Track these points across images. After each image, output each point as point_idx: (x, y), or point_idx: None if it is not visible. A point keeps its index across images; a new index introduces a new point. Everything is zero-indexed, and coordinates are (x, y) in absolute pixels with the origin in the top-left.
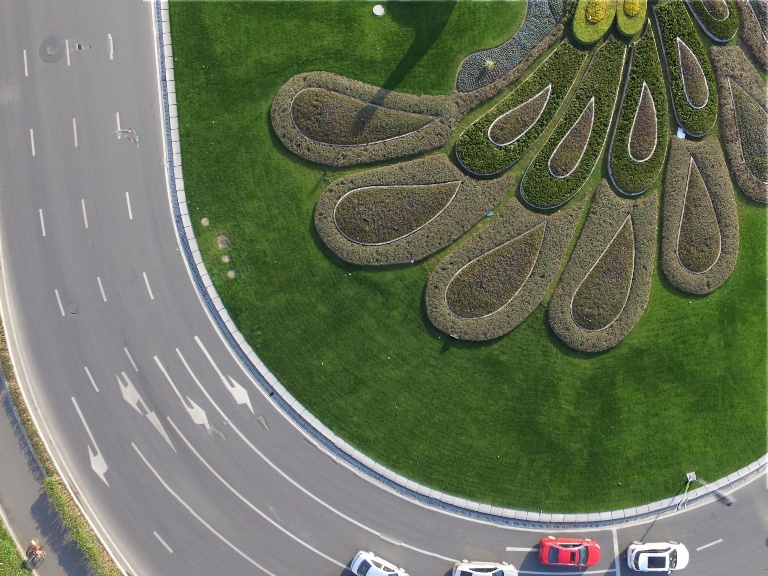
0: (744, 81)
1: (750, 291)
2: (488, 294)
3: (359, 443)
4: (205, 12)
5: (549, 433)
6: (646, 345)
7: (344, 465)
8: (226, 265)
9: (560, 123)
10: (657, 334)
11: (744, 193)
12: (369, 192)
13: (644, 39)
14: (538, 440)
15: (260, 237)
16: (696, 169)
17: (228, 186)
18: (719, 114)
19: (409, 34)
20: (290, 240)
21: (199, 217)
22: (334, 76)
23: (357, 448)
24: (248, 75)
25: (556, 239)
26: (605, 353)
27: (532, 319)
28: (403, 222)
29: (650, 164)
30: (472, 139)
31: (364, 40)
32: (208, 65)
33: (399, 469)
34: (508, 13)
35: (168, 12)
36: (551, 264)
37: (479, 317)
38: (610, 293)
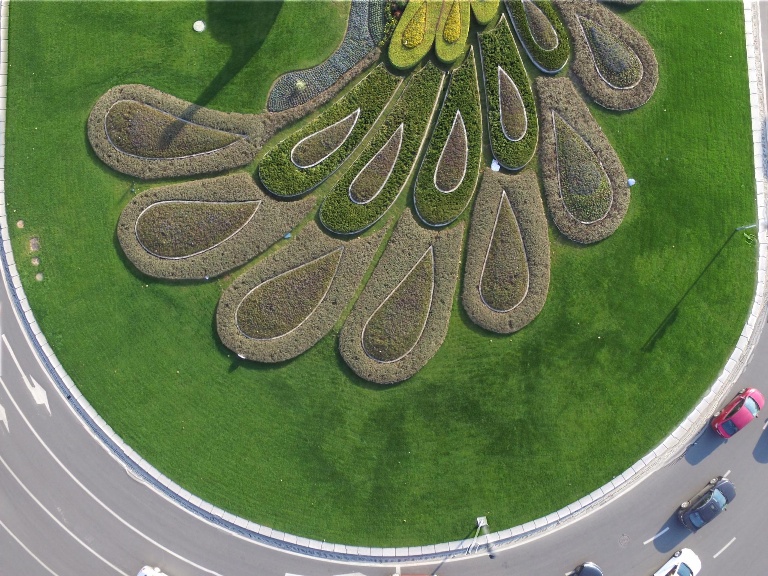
0: (569, 115)
1: (558, 334)
2: (277, 316)
3: (147, 453)
4: (40, 21)
5: (333, 462)
6: (440, 381)
7: (128, 473)
8: (35, 268)
9: (366, 148)
10: (453, 371)
11: (560, 231)
12: (170, 206)
13: (463, 66)
14: (322, 468)
15: (68, 243)
16: (508, 203)
17: (43, 191)
18: (539, 148)
19: (226, 51)
20: (94, 248)
21: (15, 219)
22: (148, 89)
23: (145, 458)
24: (72, 84)
25: (351, 266)
26: (396, 386)
27: (323, 345)
28: (200, 238)
29: (456, 196)
30: (274, 159)
31: (182, 55)
32: (37, 73)
33: (184, 483)
34: (326, 34)
35: (8, 19)
36: (344, 291)
37: (268, 339)
38: (403, 325)
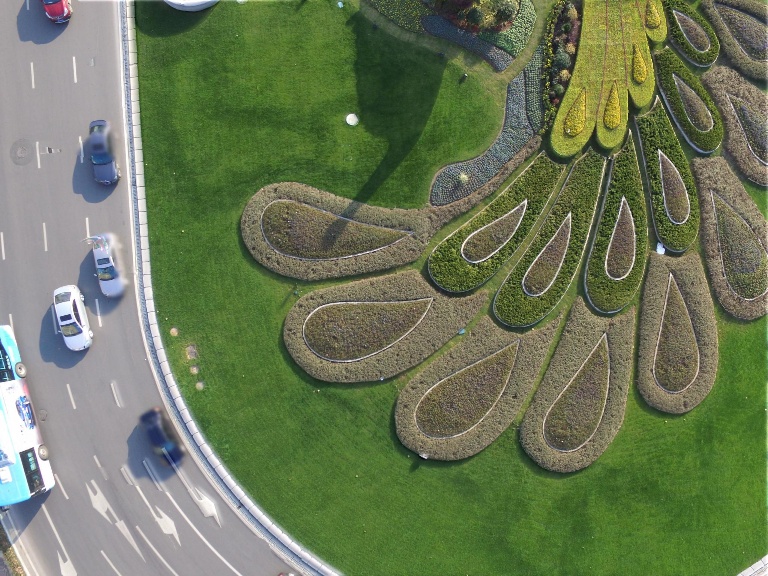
0: (727, 194)
1: (728, 410)
2: (458, 414)
3: (326, 559)
4: (176, 117)
5: (519, 553)
6: (620, 465)
7: None
8: (194, 377)
9: (535, 239)
10: (631, 454)
11: (724, 309)
12: (339, 308)
13: (624, 152)
14: (507, 560)
15: (229, 350)
16: (675, 286)
17: (197, 297)
18: (701, 228)
19: (383, 145)
20: (259, 354)
21: (168, 328)
22: (305, 188)
23: (324, 564)
24: (219, 184)
25: (529, 359)
26: (577, 473)
27: (503, 438)
28: (373, 340)
29: (627, 282)
30: (445, 256)
31: (337, 150)
32: (179, 172)
33: None
34: (485, 124)
35: (139, 116)
36: (523, 384)
37: (449, 437)
38: (583, 414)
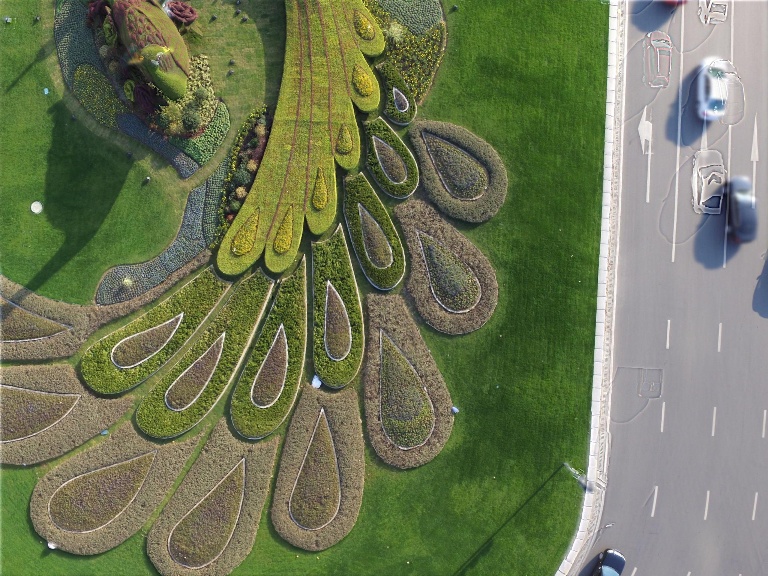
0: (397, 336)
1: (366, 556)
2: (87, 513)
3: None
4: None
5: None
6: None
7: None
8: None
9: (186, 354)
10: None
11: (377, 454)
12: None
13: (292, 278)
14: None
15: None
16: (325, 422)
17: None
18: (364, 367)
19: (60, 236)
20: None
21: None
22: None
23: None
24: None
25: (161, 471)
26: None
27: (131, 543)
28: (19, 426)
29: (271, 412)
30: (95, 356)
31: (18, 235)
32: None
33: None
34: (159, 229)
35: None
36: (153, 495)
37: (78, 532)
38: (208, 535)
